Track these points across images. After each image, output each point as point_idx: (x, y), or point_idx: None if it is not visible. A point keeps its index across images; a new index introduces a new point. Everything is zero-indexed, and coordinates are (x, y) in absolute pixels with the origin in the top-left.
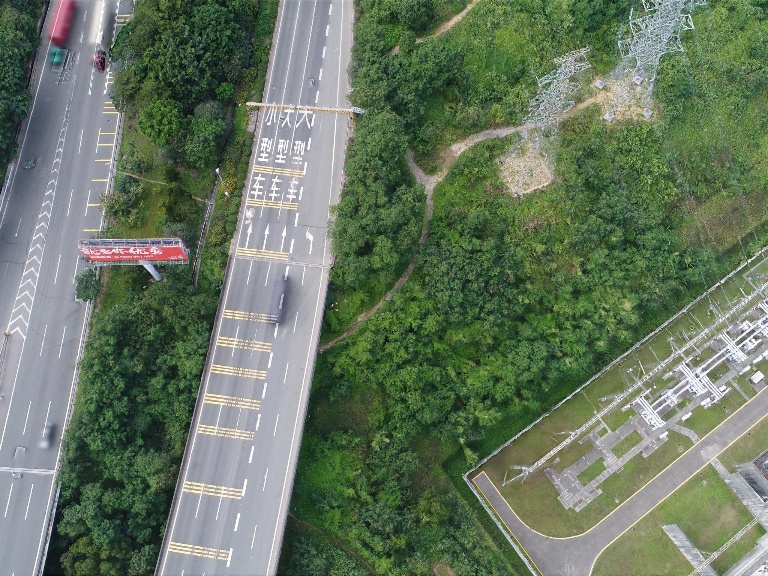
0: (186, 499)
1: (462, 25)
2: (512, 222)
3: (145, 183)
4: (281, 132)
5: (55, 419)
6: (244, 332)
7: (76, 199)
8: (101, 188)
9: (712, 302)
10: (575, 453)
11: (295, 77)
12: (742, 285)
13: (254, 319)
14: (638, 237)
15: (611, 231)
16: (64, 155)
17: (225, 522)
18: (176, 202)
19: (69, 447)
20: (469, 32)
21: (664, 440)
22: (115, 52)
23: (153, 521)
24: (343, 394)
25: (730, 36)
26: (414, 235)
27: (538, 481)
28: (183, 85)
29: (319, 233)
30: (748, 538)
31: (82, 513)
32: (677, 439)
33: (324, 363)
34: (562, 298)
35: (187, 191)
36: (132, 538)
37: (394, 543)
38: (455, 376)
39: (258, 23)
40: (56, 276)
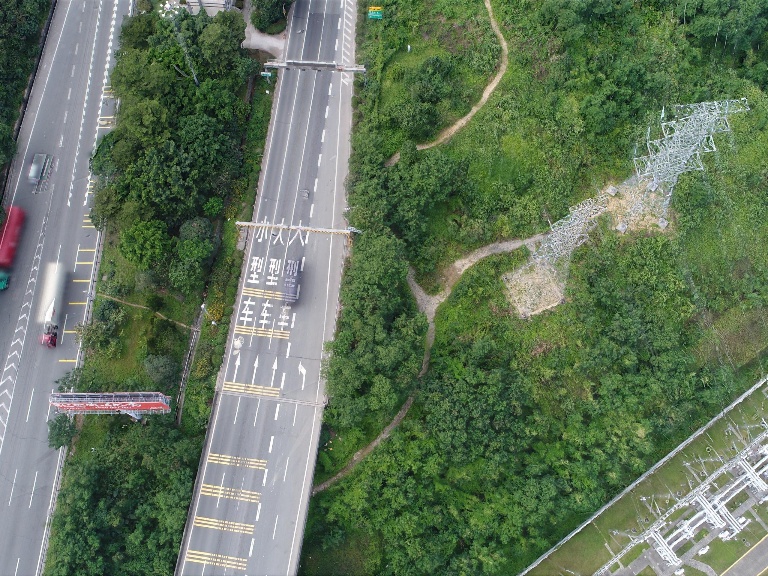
0: None
1: (467, 131)
2: (519, 347)
3: (126, 307)
4: (273, 250)
5: None
6: (230, 479)
7: None
8: (79, 312)
9: (730, 421)
10: None
11: (288, 188)
12: (761, 402)
13: (241, 464)
14: (653, 358)
15: (624, 353)
16: (40, 274)
17: None
18: (158, 335)
19: None
20: (474, 139)
21: None
22: (95, 165)
23: None
24: (337, 544)
25: (749, 137)
26: (414, 371)
27: None
28: (168, 203)
29: (312, 366)
30: None
31: None
32: (693, 575)
33: (317, 508)
34: (572, 426)
35: (171, 317)
36: None
37: None
38: (457, 515)
39: (250, 127)
40: (28, 413)
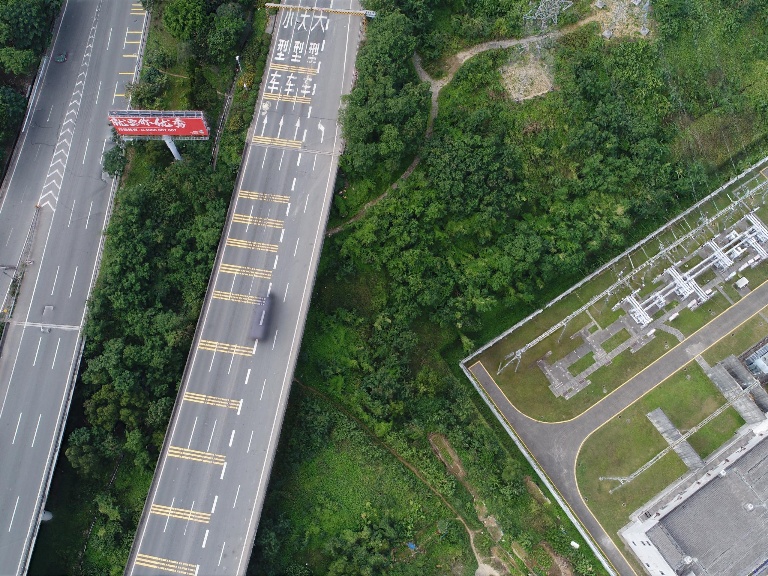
0: (201, 355)
1: None
2: (512, 125)
3: (169, 77)
4: (297, 34)
5: (81, 282)
6: (258, 210)
7: (104, 90)
8: None
9: (702, 215)
10: (566, 347)
11: None
12: None
13: (268, 199)
14: (632, 146)
15: (606, 139)
16: (94, 50)
17: (237, 376)
18: (198, 90)
19: (94, 304)
20: None
21: (651, 338)
22: None
23: (170, 378)
24: (349, 273)
25: None
26: (419, 127)
27: (531, 371)
28: None
29: (330, 125)
30: (728, 427)
31: (105, 363)
32: (664, 337)
33: (332, 245)
34: (558, 200)
35: None
36: (150, 392)
37: (393, 408)
38: (455, 266)
39: None
40: (84, 157)
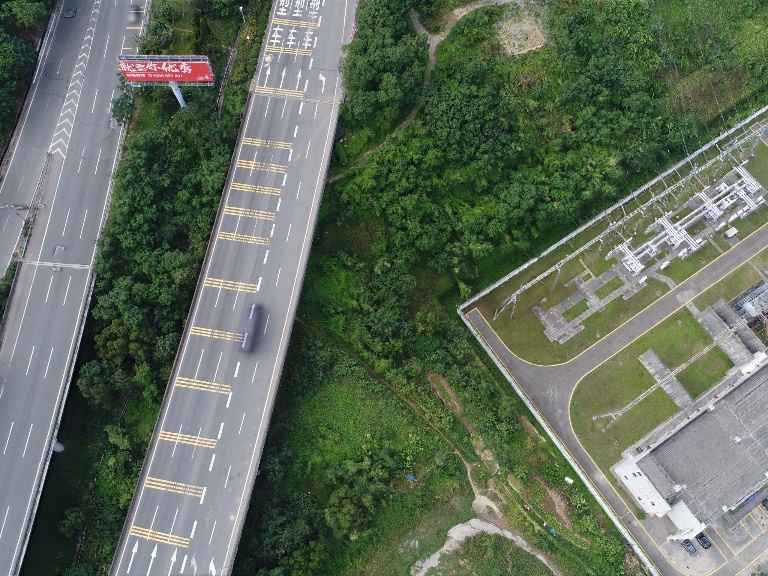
0: (207, 292)
1: None
2: (507, 78)
3: None
4: None
5: (91, 224)
6: (261, 156)
7: (112, 43)
8: None
9: None
10: (561, 294)
11: None
12: None
13: (271, 146)
14: (624, 100)
15: (599, 92)
16: (102, 6)
17: (241, 311)
18: (203, 41)
19: (104, 243)
20: None
21: (643, 285)
22: None
23: (177, 315)
24: (349, 217)
25: None
26: (417, 76)
27: (526, 317)
28: None
29: (331, 75)
30: (718, 370)
31: (114, 298)
32: (655, 285)
33: (333, 192)
34: (552, 151)
35: None
36: (158, 328)
37: (392, 346)
38: (452, 214)
39: None
40: (93, 107)
